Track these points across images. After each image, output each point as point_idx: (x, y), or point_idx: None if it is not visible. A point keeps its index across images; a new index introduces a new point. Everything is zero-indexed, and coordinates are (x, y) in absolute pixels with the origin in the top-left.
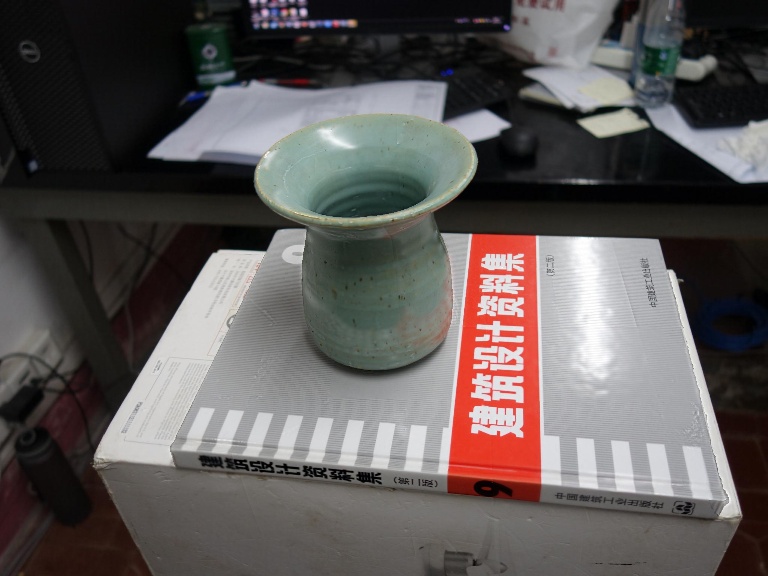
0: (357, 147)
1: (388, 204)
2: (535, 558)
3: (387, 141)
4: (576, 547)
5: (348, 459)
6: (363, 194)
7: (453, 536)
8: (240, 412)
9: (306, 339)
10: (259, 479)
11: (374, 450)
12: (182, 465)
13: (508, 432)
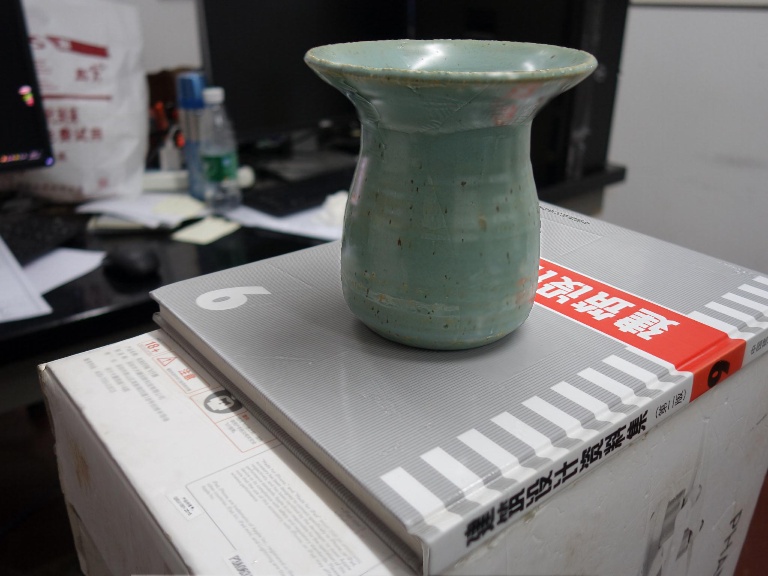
0: None
1: None
2: (721, 456)
3: (395, 66)
4: (745, 417)
5: (609, 416)
6: None
7: (678, 473)
8: (436, 450)
9: (377, 355)
10: (526, 521)
11: (616, 394)
12: (436, 569)
13: (666, 326)
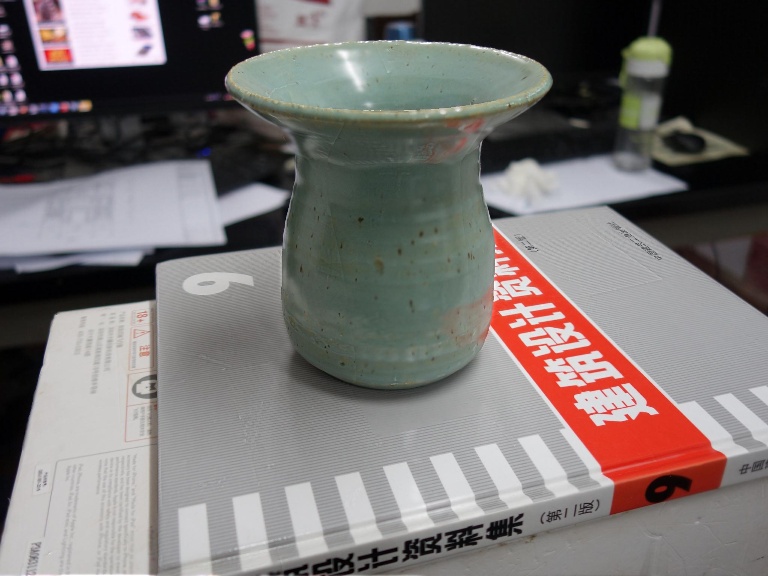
0: (334, 81)
1: None
2: None
3: (372, 71)
4: (742, 543)
5: (467, 509)
6: None
7: None
8: (253, 495)
9: (290, 375)
10: None
11: (495, 484)
12: None
13: (637, 412)
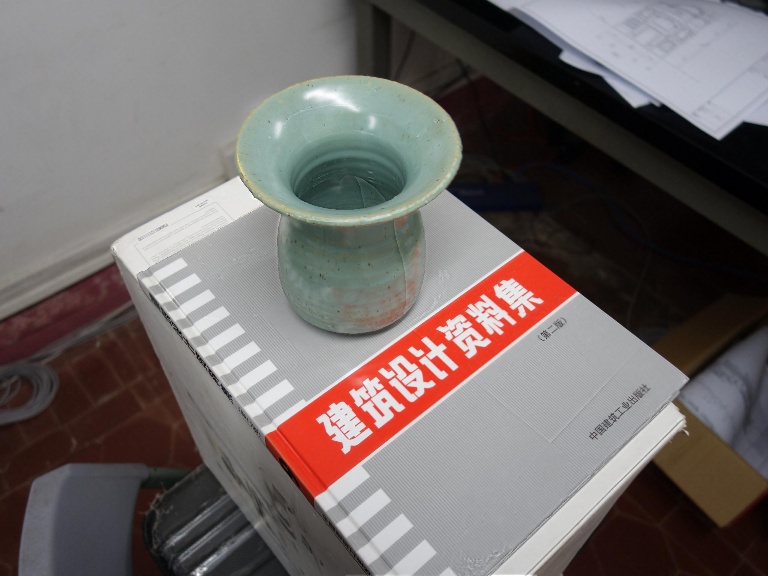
0: (387, 119)
1: (397, 185)
2: (320, 543)
3: (412, 128)
4: (341, 562)
5: (222, 369)
6: (379, 164)
7: (275, 479)
8: (198, 280)
9: None
10: None
11: (243, 377)
12: None
13: (340, 441)
